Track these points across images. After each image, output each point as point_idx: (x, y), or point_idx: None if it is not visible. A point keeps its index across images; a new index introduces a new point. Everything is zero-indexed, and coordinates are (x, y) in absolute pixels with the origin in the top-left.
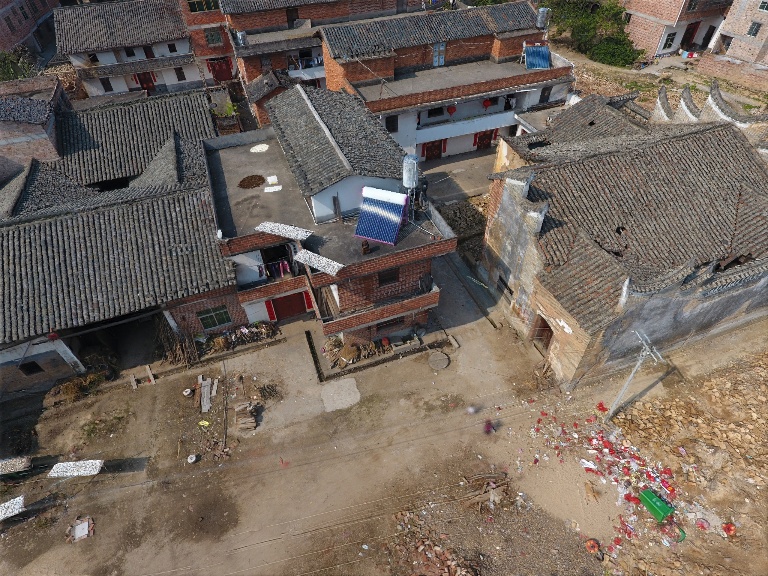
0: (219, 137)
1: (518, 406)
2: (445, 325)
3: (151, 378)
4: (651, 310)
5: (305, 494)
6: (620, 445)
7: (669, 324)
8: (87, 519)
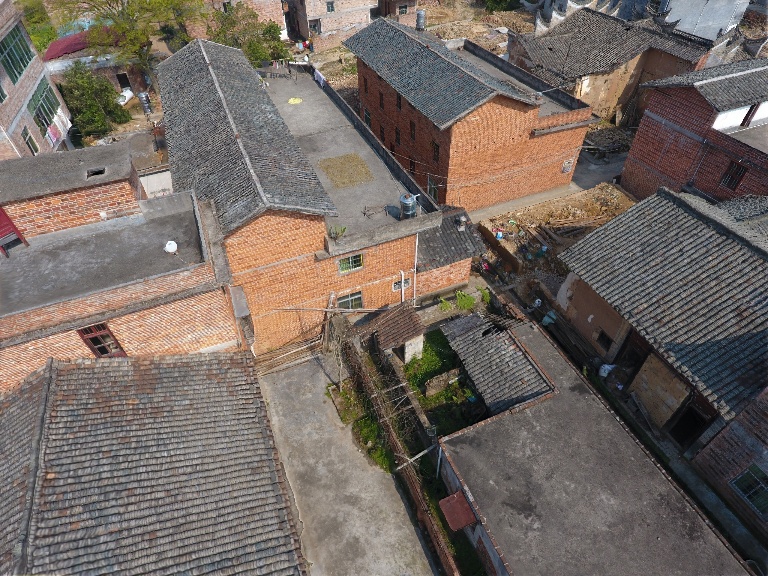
0: (767, 154)
1: None
2: None
3: None
4: None
5: None
6: None
7: None
8: None
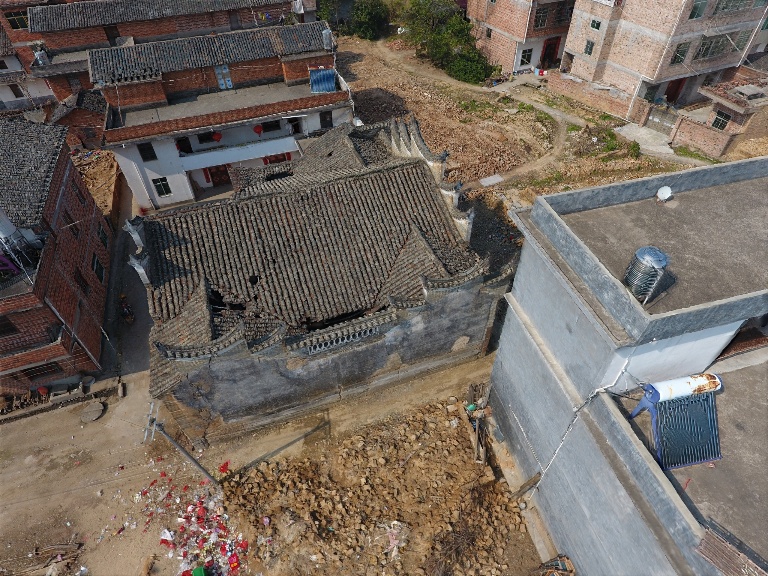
0: None
1: (143, 465)
2: (125, 371)
3: None
4: (231, 372)
5: None
6: (215, 513)
7: (284, 382)
8: None
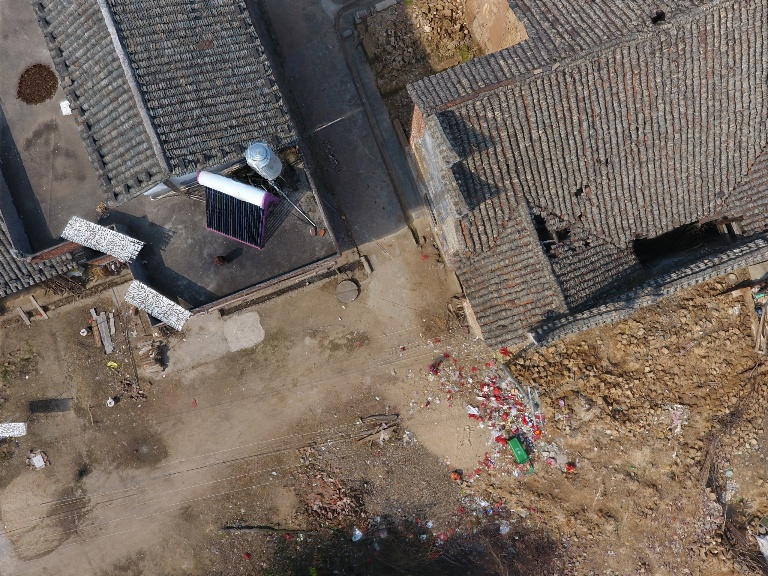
0: None
1: (423, 346)
2: (359, 240)
3: (41, 312)
4: None
5: (221, 431)
6: (508, 392)
7: None
8: (39, 453)
